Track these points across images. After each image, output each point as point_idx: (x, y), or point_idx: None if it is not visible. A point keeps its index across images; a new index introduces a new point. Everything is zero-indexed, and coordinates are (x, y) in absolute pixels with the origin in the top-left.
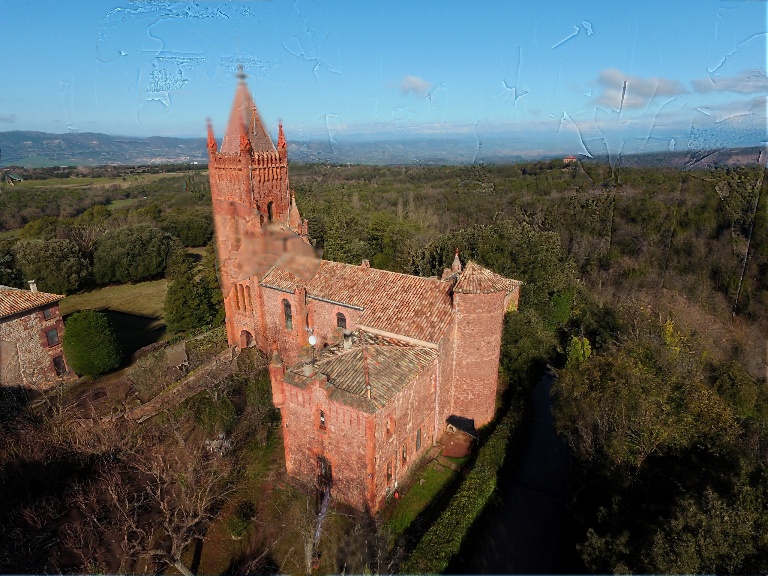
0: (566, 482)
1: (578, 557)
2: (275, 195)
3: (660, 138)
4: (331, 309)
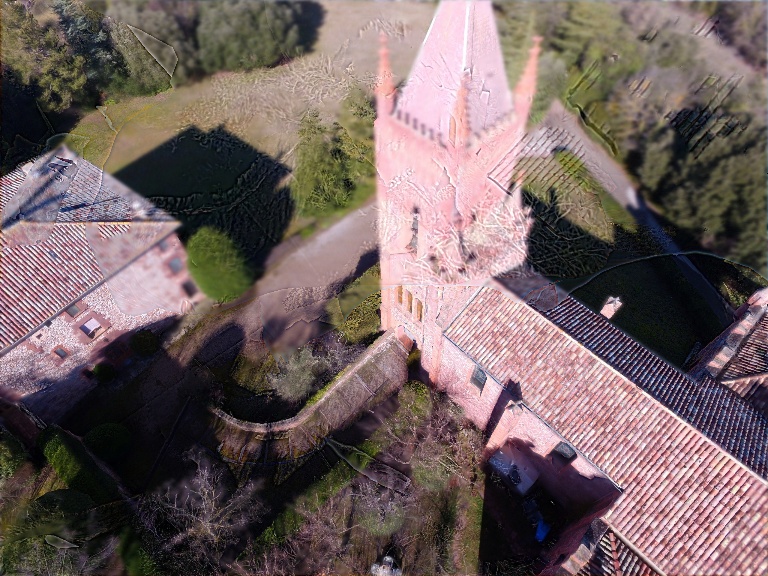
0: None
1: None
2: None
3: None
4: (556, 433)
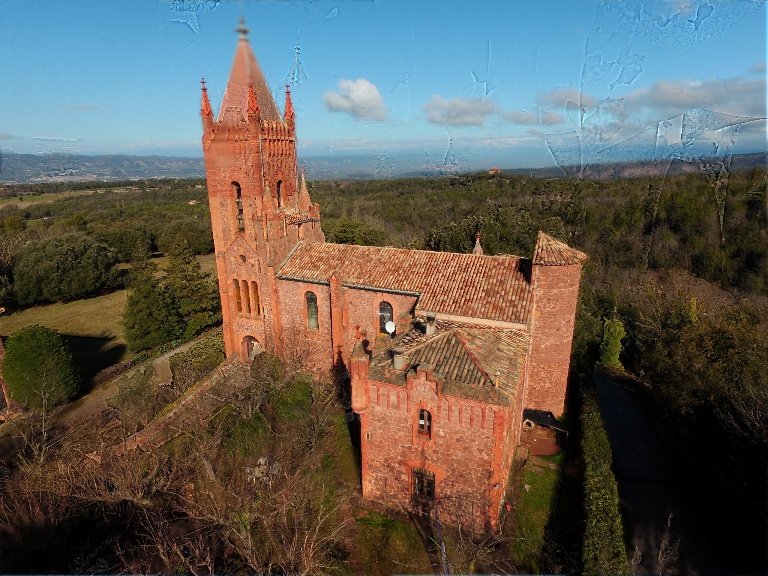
0: (670, 470)
1: (737, 553)
2: (284, 173)
3: None
4: (373, 298)
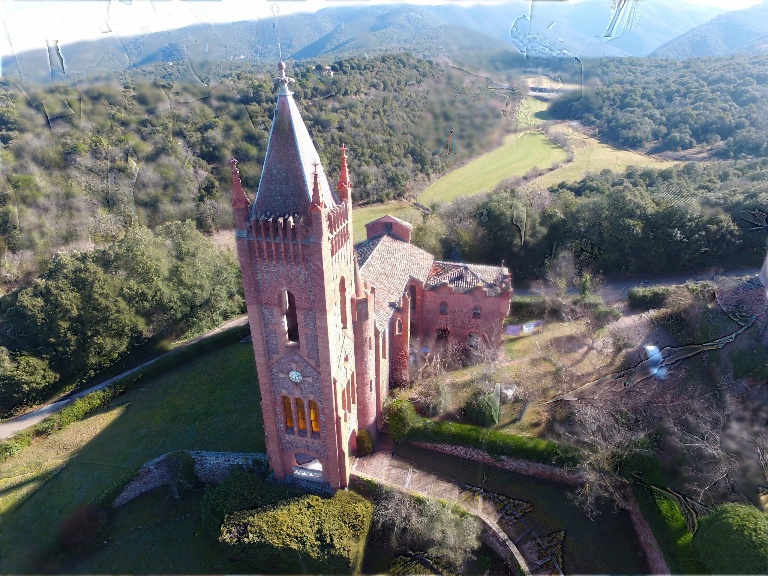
0: None
1: None
2: None
3: (21, 116)
4: None
